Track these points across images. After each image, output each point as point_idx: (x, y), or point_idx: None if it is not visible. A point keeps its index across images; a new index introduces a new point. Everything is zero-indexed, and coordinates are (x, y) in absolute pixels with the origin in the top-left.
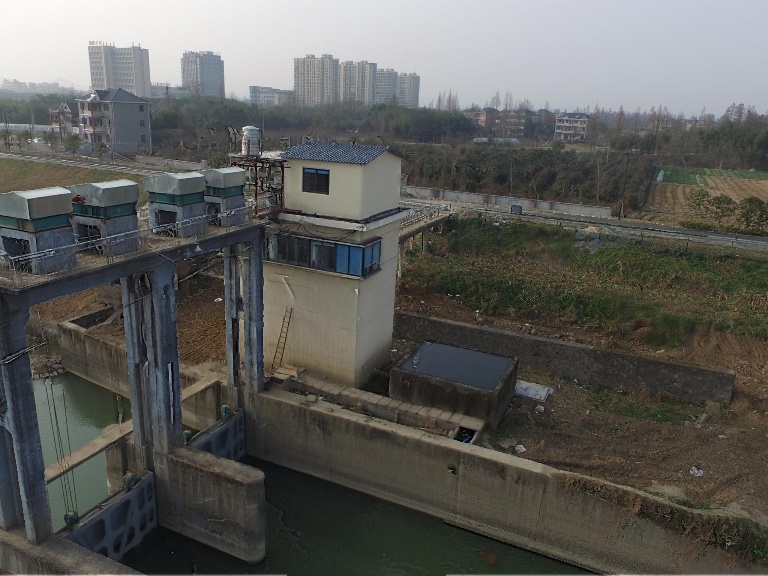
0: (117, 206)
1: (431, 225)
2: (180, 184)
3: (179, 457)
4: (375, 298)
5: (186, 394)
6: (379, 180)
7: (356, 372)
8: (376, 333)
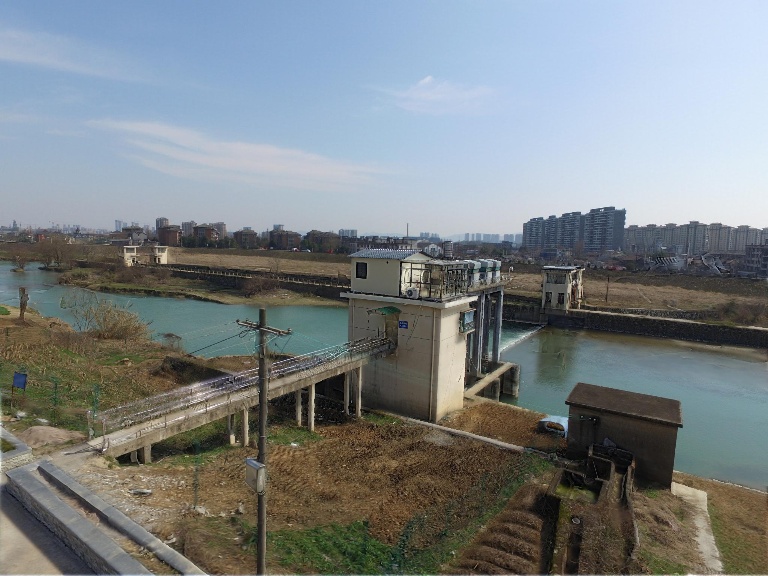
0: None
1: None
2: None
3: None
4: None
5: (475, 387)
6: None
7: None
8: None
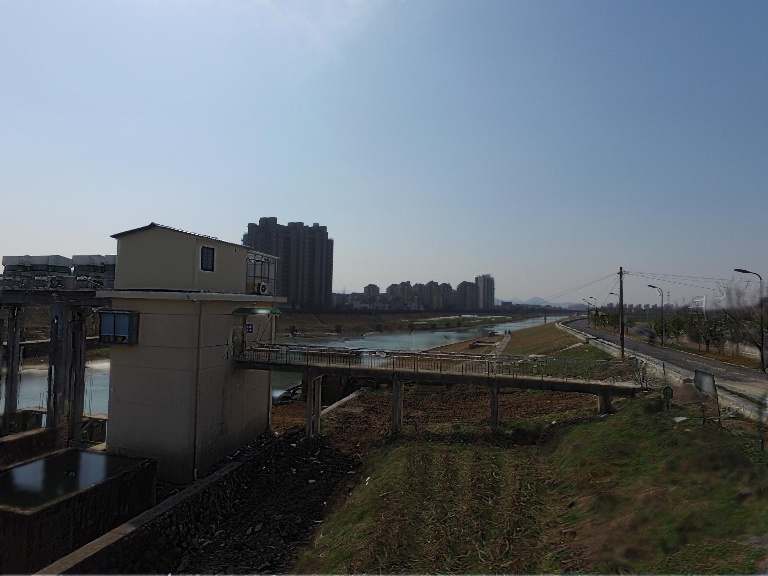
0: (38, 265)
1: (523, 383)
2: (73, 258)
3: (38, 428)
4: (144, 381)
5: None
6: (150, 256)
7: (109, 448)
8: (148, 425)
